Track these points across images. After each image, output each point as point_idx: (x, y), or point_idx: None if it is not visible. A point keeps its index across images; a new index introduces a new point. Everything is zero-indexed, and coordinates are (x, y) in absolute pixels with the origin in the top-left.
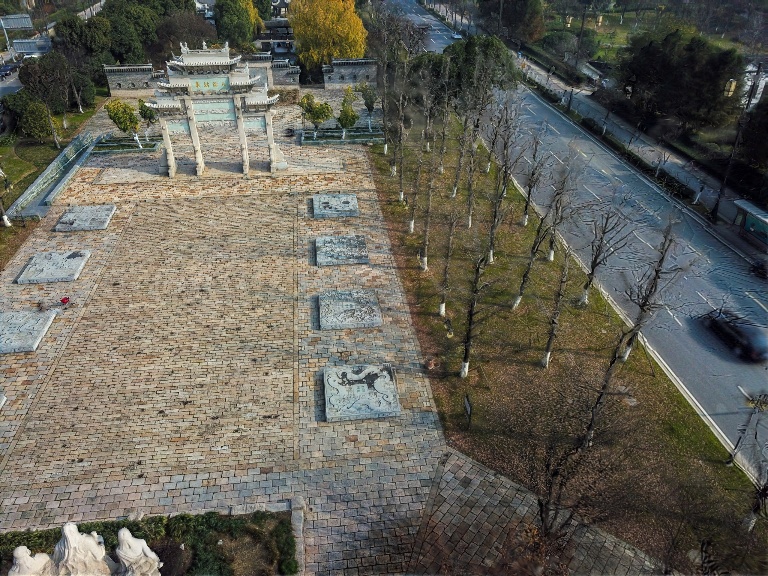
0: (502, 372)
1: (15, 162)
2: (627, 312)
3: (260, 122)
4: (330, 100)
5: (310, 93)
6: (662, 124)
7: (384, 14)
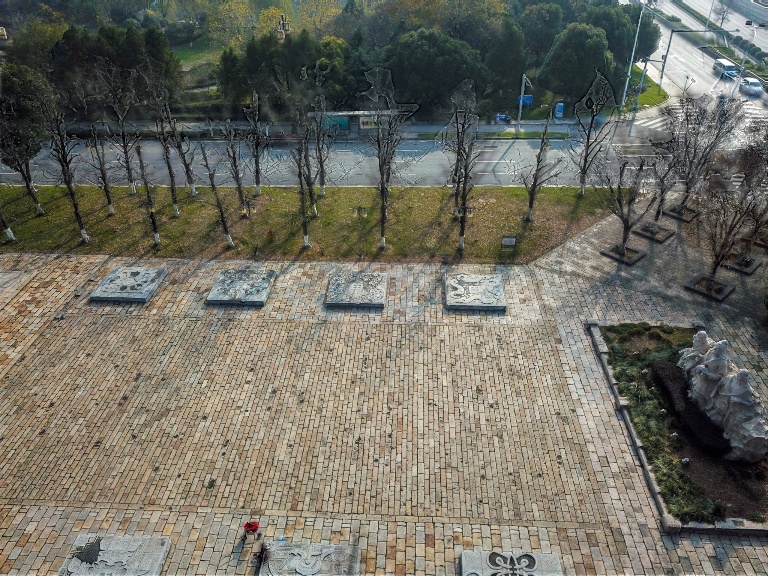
0: None
1: None
2: None
3: None
4: None
5: None
6: None
7: None
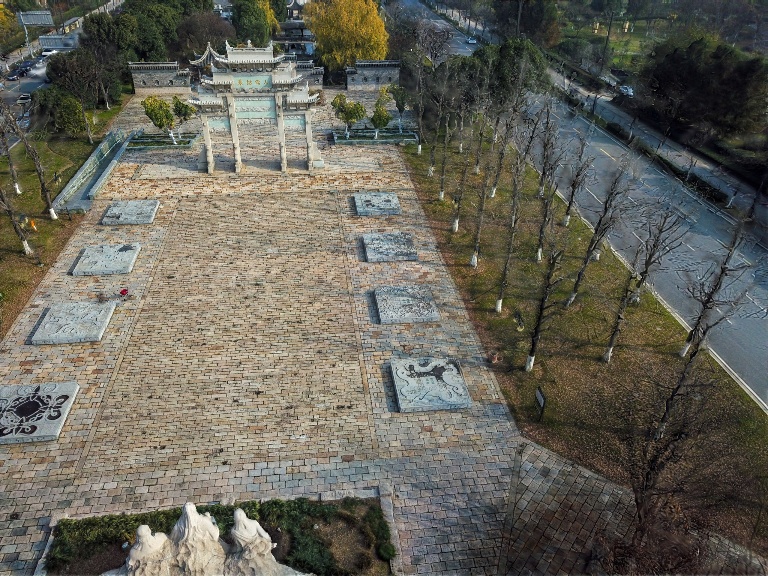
0: (565, 366)
1: (50, 156)
2: (678, 310)
3: (300, 120)
4: (354, 101)
5: (333, 94)
6: (686, 130)
7: (400, 18)
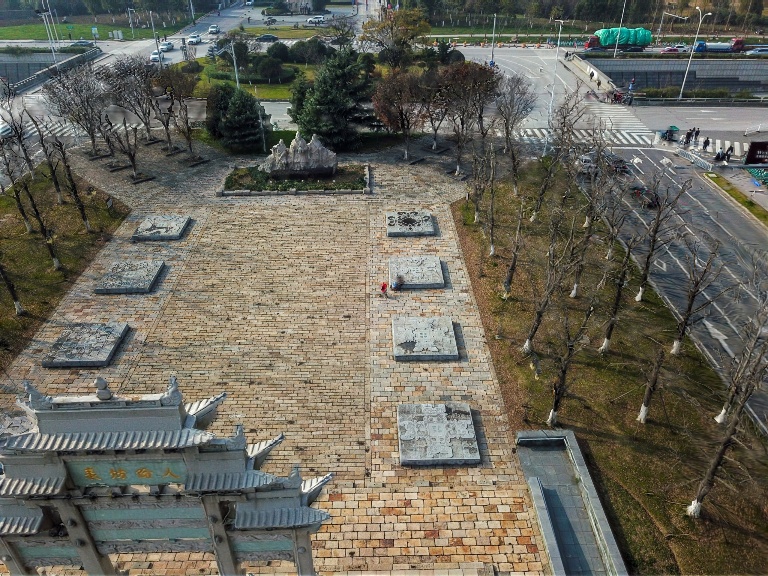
0: None
1: None
2: None
3: None
4: None
5: None
6: None
7: None
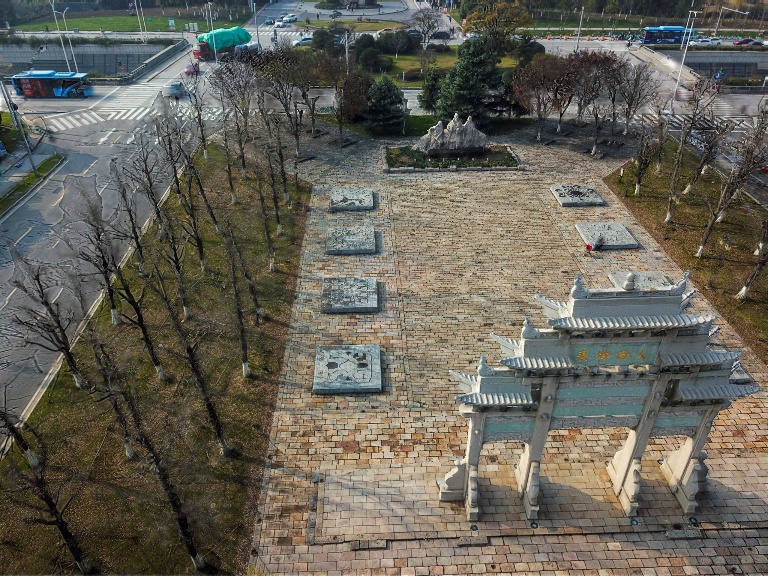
0: None
1: None
2: None
3: None
4: None
5: None
6: None
7: None
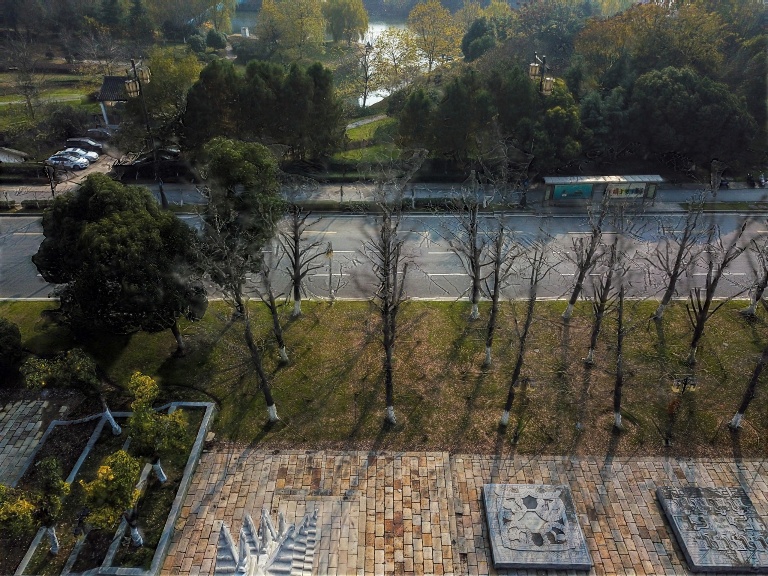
0: None
1: None
2: None
3: None
4: None
5: None
6: None
7: None
